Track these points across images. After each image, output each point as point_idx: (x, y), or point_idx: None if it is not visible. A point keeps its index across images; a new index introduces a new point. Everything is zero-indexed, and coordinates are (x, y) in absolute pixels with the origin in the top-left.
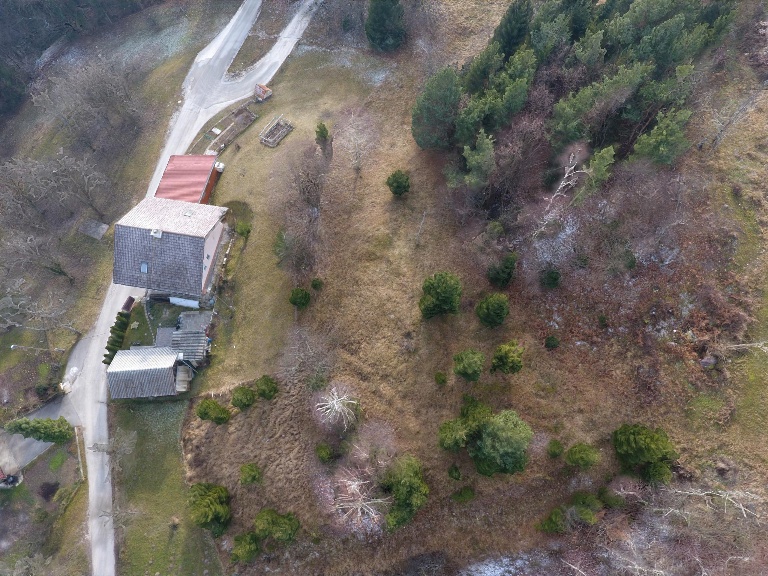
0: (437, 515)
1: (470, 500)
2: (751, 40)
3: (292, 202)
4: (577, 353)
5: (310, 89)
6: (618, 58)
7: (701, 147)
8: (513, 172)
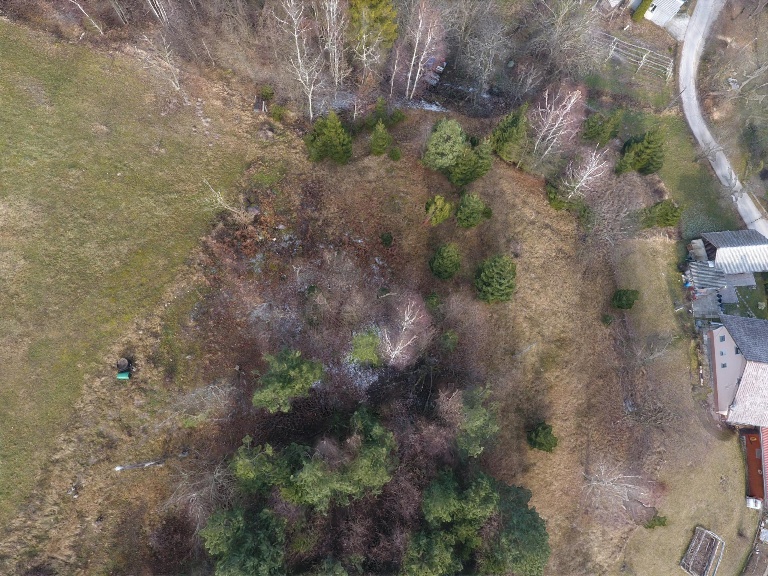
0: None
1: None
2: None
3: None
4: (364, 231)
5: None
6: (288, 571)
7: None
8: None
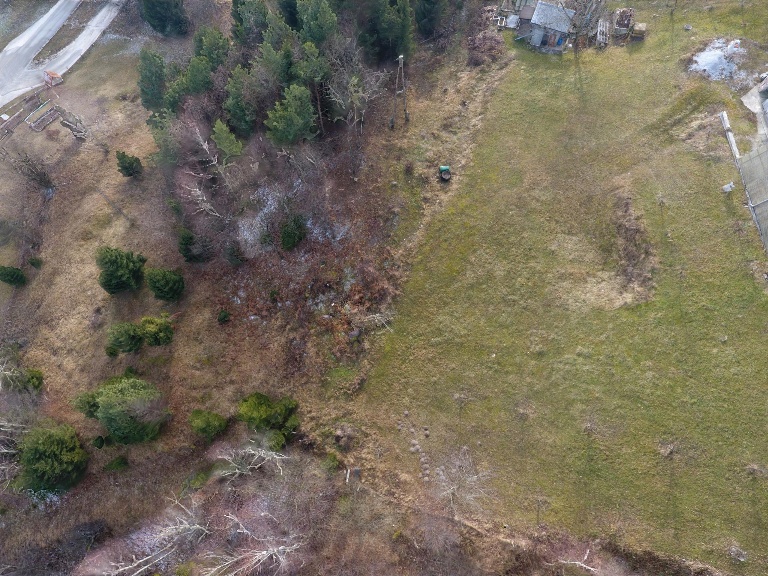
0: (105, 485)
1: (129, 470)
2: (474, 24)
3: (31, 183)
4: (247, 327)
5: (98, 76)
6: None
7: (393, 127)
8: (214, 152)
